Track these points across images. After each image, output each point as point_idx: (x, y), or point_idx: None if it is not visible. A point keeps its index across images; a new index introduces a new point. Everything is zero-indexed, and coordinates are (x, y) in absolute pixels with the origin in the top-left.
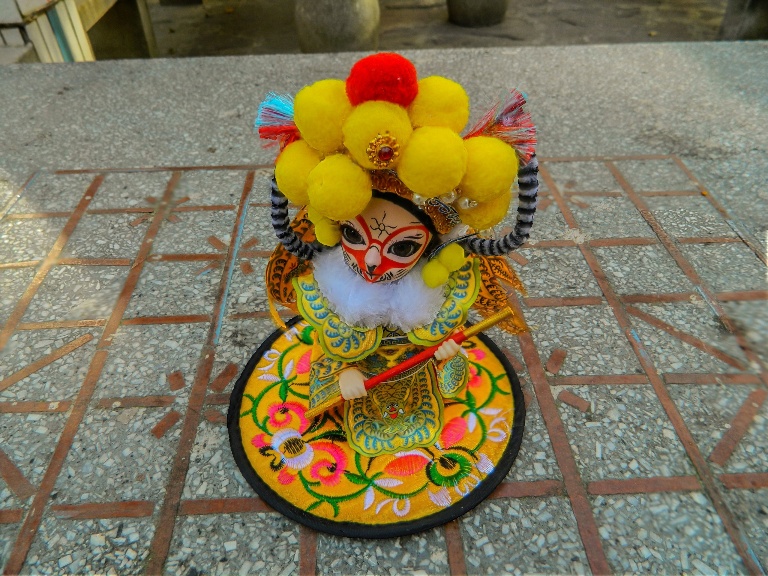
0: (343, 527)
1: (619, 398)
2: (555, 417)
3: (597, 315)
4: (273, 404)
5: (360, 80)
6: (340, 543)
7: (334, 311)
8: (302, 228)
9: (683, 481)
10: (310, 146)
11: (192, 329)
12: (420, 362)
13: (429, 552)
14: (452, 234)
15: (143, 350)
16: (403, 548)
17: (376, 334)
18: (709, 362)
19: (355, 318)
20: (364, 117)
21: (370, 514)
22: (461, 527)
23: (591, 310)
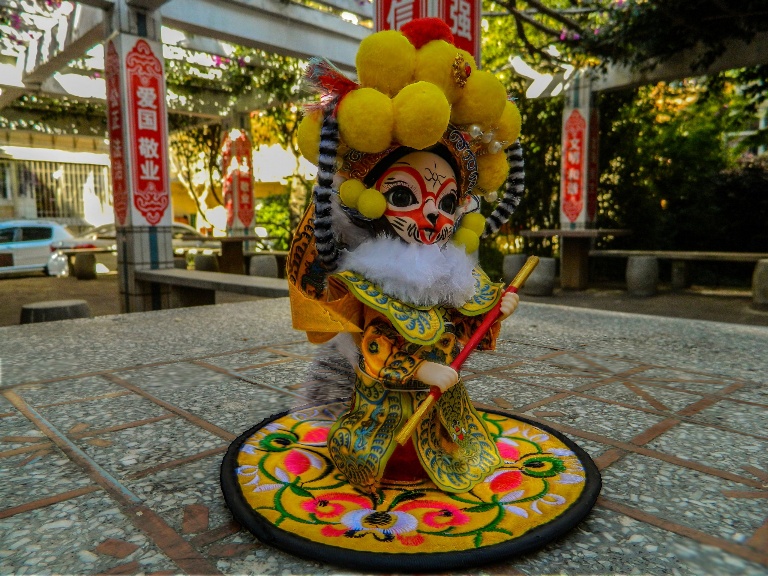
0: (534, 533)
1: (570, 405)
2: (552, 424)
3: (488, 380)
4: (303, 503)
5: (424, 23)
6: (542, 560)
7: (393, 293)
8: (303, 244)
9: (668, 421)
10: (375, 89)
11: (78, 503)
12: (490, 326)
13: (616, 523)
14: (459, 212)
15: (7, 546)
16: (594, 533)
17: (436, 314)
18: (582, 380)
19: (430, 280)
20: (440, 45)
21: (538, 516)
22: (607, 498)
23: (480, 379)
